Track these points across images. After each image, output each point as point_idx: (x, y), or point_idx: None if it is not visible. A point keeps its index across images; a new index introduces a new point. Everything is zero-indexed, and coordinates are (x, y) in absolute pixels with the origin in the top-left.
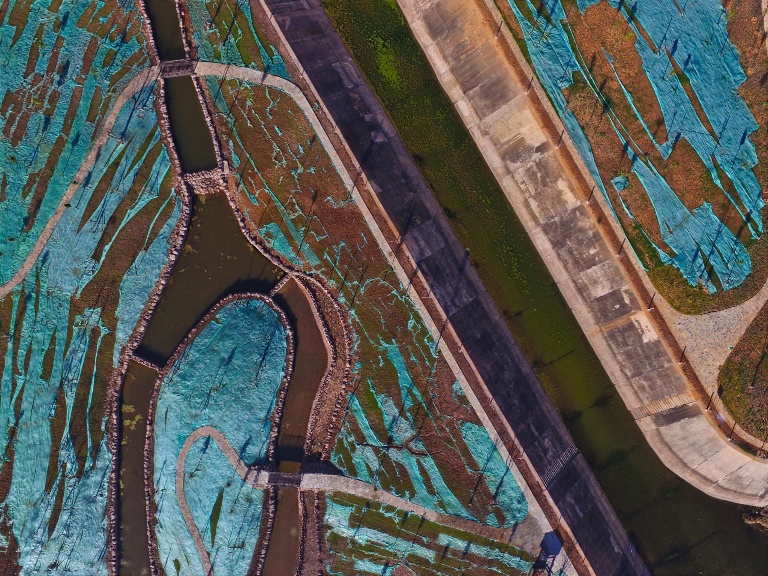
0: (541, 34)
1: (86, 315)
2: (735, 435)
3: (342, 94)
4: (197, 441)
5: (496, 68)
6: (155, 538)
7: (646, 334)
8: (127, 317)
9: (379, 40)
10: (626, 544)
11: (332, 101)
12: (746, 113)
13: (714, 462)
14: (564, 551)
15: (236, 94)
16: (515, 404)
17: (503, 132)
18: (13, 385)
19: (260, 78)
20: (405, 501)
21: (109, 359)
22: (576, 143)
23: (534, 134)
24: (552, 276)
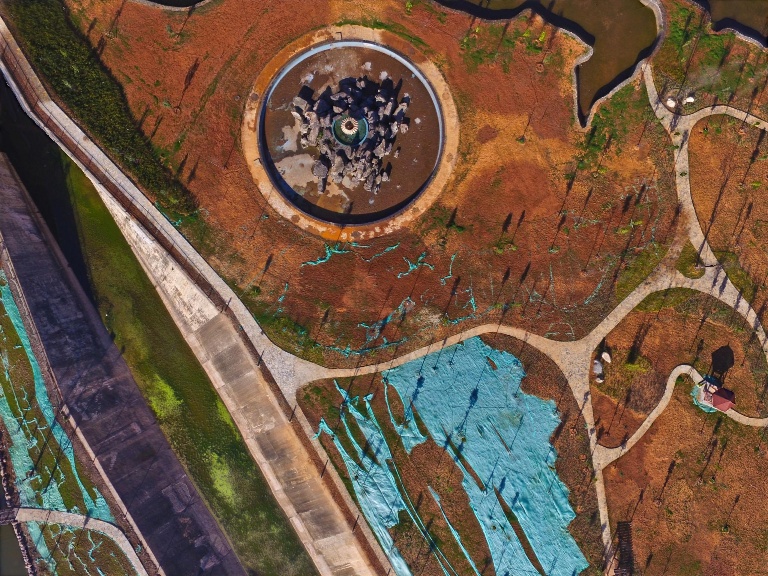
0: (366, 474)
1: None
2: None
3: (170, 524)
4: None
5: (323, 503)
6: None
7: None
8: None
9: (214, 455)
10: None
11: (157, 537)
12: (576, 551)
13: None
14: None
15: (58, 538)
16: None
17: (334, 557)
18: None
19: (82, 522)
20: None
21: None
22: None
23: (362, 569)
24: None
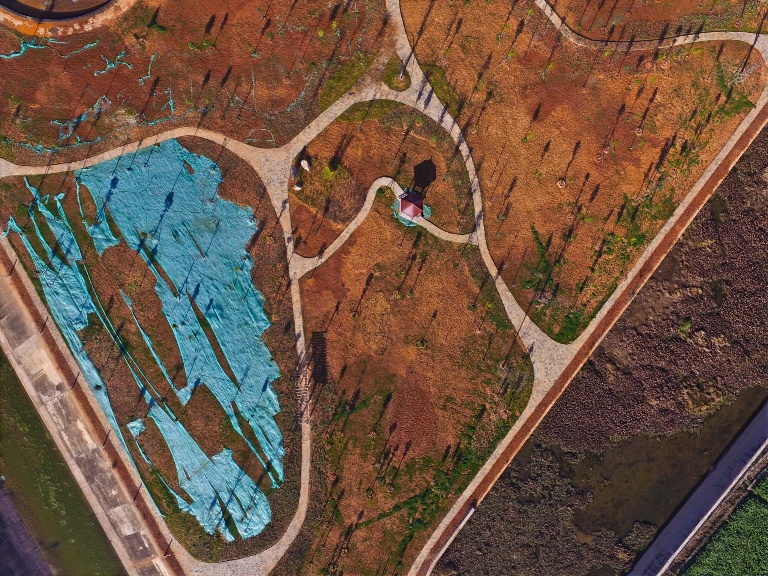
0: (55, 274)
1: None
2: None
3: None
4: None
5: (14, 305)
6: None
7: None
8: None
9: None
10: None
11: None
12: (269, 360)
13: None
14: None
15: None
16: None
17: (31, 365)
18: None
19: None
20: None
21: None
22: (92, 385)
23: (52, 373)
24: (91, 507)
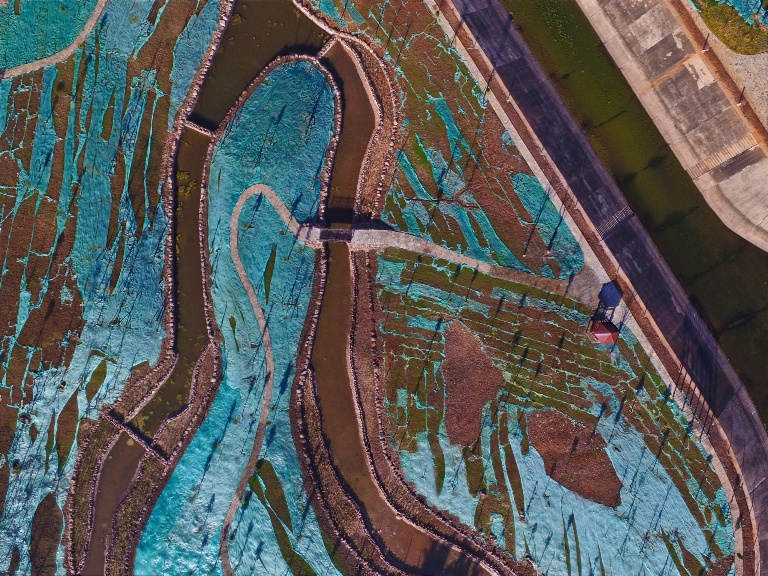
0: None
1: (142, 76)
2: None
3: None
4: (250, 199)
5: None
6: (211, 299)
7: (701, 79)
8: (180, 81)
9: None
10: (688, 308)
11: None
12: None
13: None
14: (624, 303)
15: None
16: (566, 158)
17: None
18: (76, 143)
19: None
20: (457, 254)
21: (164, 123)
22: None
23: None
24: (599, 36)
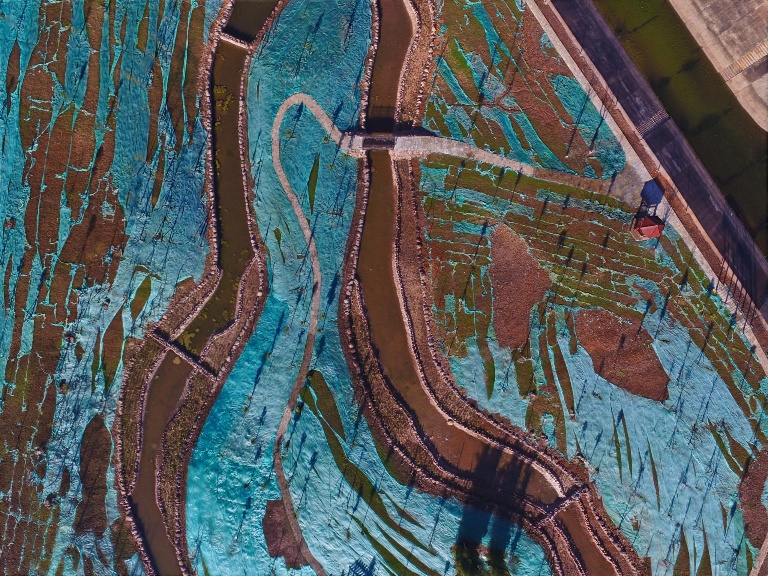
0: None
1: None
2: None
3: None
4: (290, 109)
5: None
6: (254, 213)
7: None
8: None
9: None
10: (726, 207)
11: None
12: None
13: None
14: (666, 200)
15: None
16: (604, 60)
17: None
18: (111, 55)
19: None
20: (500, 157)
21: (200, 35)
22: None
23: None
24: None
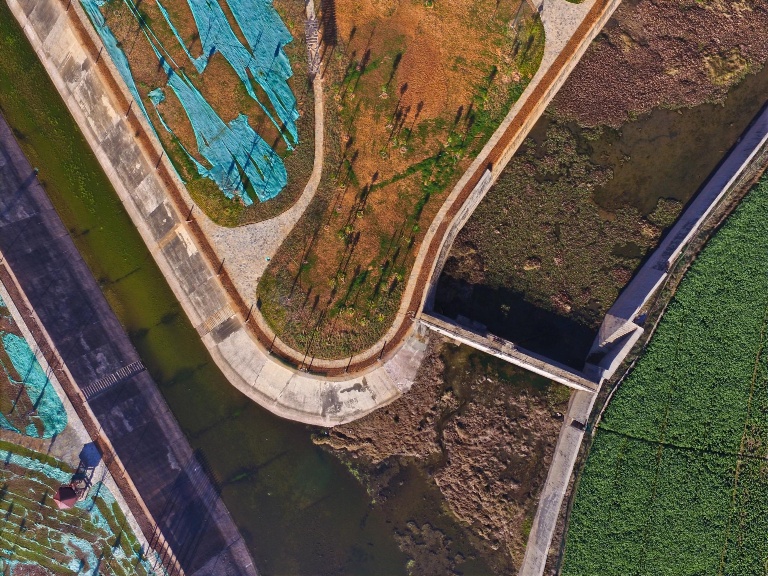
0: None
1: None
2: (275, 348)
3: None
4: None
5: None
6: None
7: (189, 247)
8: None
9: None
10: (189, 462)
11: None
12: (280, 26)
13: (265, 378)
14: (103, 463)
15: None
16: (64, 317)
17: (58, 53)
18: None
19: None
20: None
21: None
22: (114, 59)
23: (78, 52)
24: (118, 195)
